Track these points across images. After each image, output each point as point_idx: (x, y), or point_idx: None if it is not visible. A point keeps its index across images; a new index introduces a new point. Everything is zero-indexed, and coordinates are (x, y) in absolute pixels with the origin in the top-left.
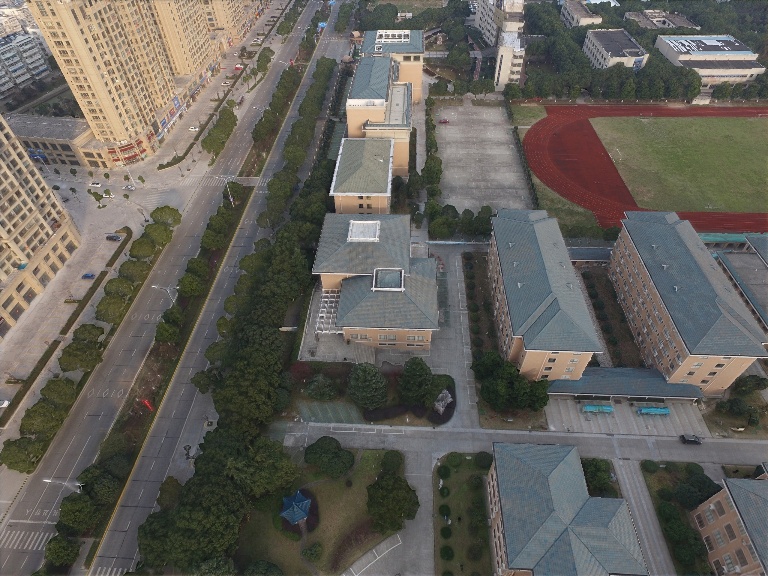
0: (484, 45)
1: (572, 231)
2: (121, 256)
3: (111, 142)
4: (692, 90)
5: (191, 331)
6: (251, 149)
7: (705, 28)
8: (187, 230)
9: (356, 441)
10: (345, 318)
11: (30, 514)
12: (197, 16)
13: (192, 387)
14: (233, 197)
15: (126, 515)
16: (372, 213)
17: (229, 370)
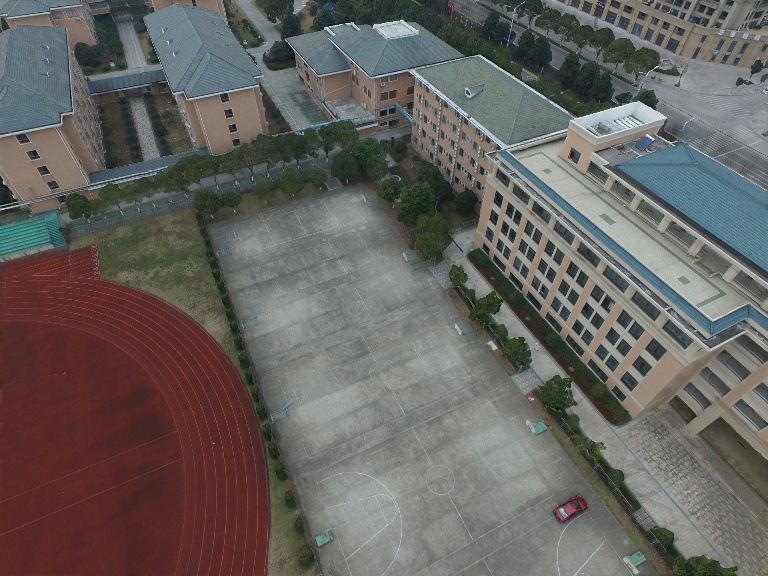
0: None
1: (149, 181)
2: None
3: None
4: None
5: None
6: None
7: None
8: (625, 91)
9: None
10: None
11: None
12: None
13: None
14: None
15: None
16: None
17: None
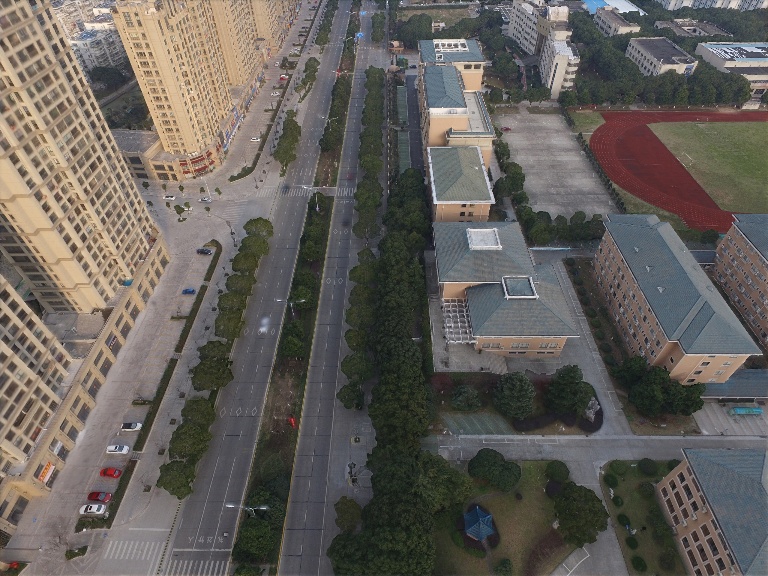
0: (523, 54)
1: None
2: (216, 270)
3: (181, 154)
4: (743, 95)
5: (310, 345)
6: (319, 159)
7: (738, 36)
8: (277, 242)
9: (512, 452)
10: (482, 327)
11: (194, 542)
12: (247, 27)
13: (327, 402)
14: (320, 207)
15: (296, 539)
16: (472, 221)
17: (365, 384)
